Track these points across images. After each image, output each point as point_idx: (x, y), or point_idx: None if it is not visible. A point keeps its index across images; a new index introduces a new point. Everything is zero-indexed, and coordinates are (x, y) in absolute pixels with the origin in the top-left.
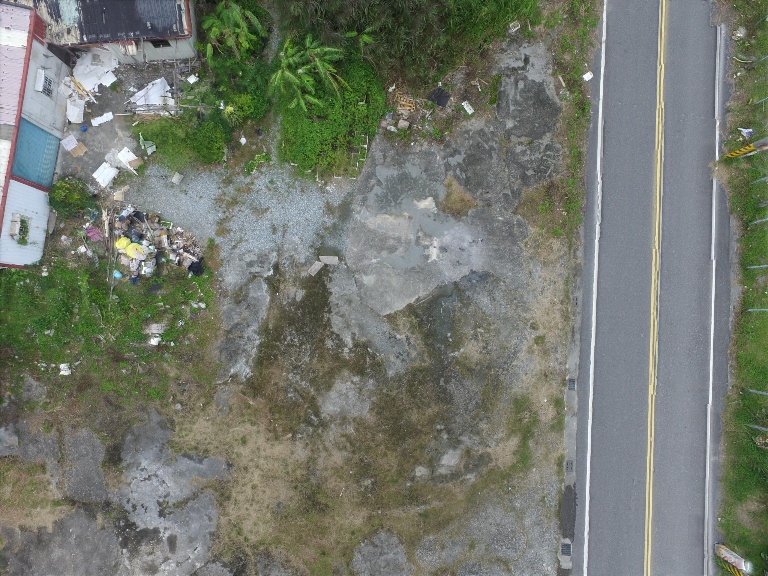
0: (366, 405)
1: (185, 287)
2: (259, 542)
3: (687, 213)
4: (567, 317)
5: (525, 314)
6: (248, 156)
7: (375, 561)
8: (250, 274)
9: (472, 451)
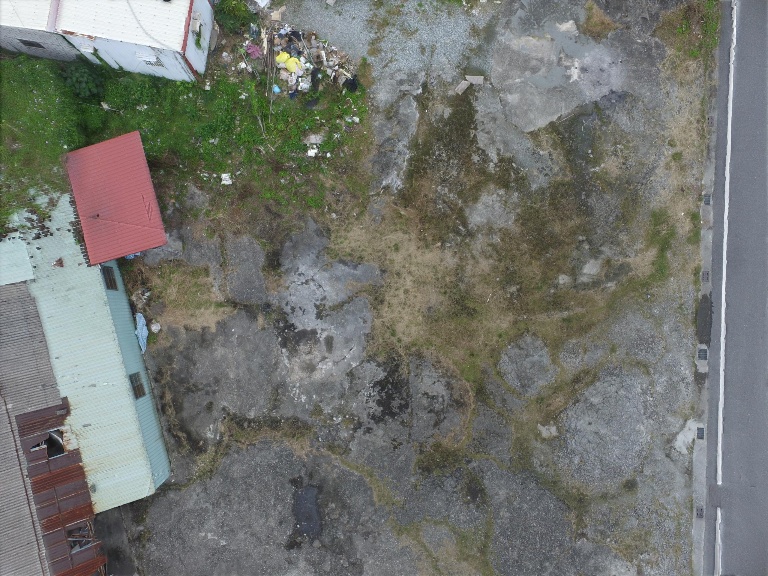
0: (511, 216)
1: (340, 102)
2: (411, 343)
3: None
4: (703, 136)
5: (663, 132)
6: None
7: (521, 363)
8: (400, 92)
9: (613, 261)
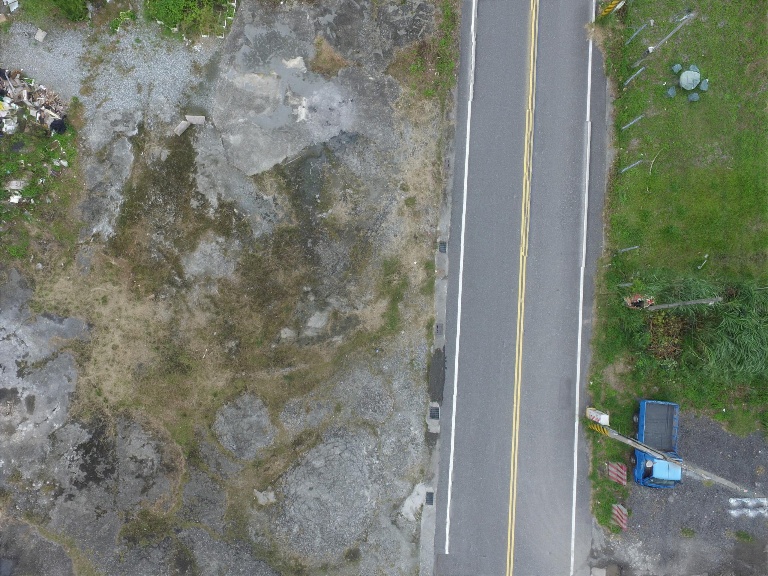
0: (231, 266)
1: (46, 145)
2: (119, 403)
3: (562, 74)
4: (439, 179)
5: (395, 175)
6: (113, 14)
7: (238, 423)
8: (114, 133)
9: (339, 313)
